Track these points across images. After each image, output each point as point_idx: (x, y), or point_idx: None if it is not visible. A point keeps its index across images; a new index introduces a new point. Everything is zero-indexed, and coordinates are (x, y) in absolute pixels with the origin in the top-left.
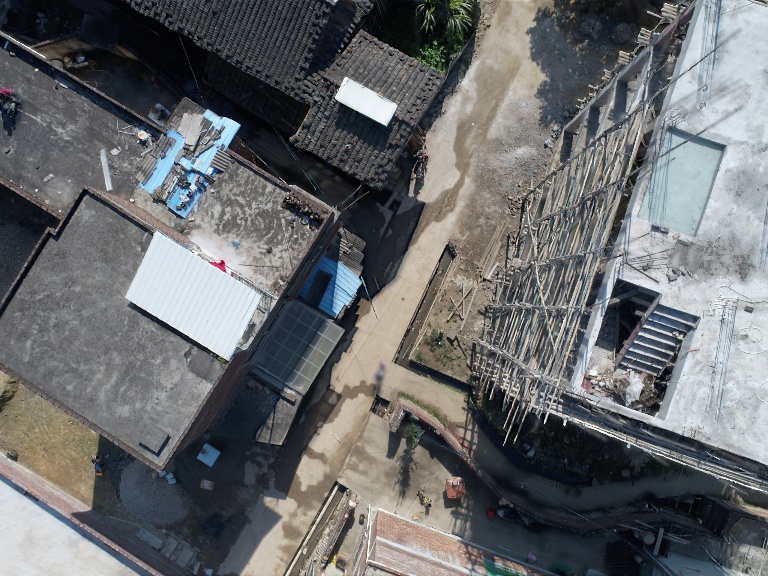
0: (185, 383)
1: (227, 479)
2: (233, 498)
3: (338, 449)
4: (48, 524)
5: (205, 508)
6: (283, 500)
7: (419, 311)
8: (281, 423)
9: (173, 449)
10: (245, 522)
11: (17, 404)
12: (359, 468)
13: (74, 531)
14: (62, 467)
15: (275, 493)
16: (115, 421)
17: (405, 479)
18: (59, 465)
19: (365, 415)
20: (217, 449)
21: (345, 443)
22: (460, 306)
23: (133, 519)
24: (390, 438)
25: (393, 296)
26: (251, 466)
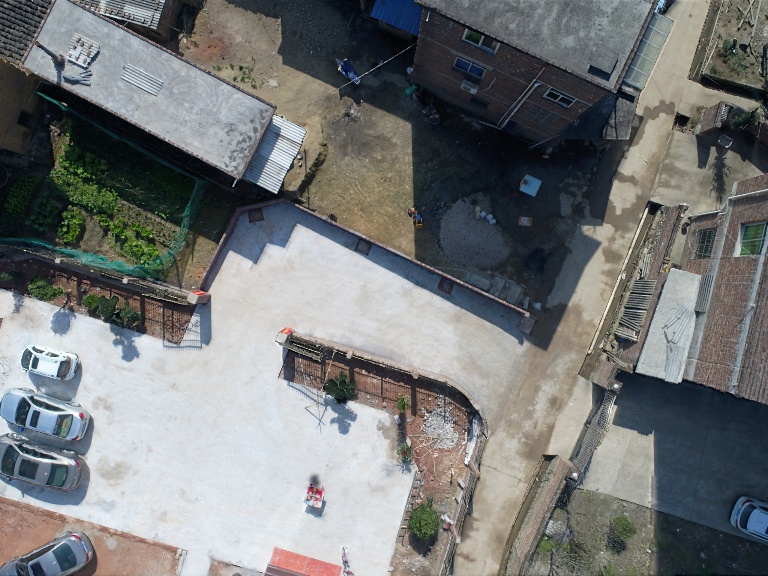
0: (625, 6)
1: (544, 213)
2: (552, 231)
3: (647, 170)
4: (381, 277)
5: (526, 245)
6: (600, 226)
7: (703, 29)
8: (623, 121)
9: (625, 68)
10: (566, 253)
11: (329, 168)
12: (671, 183)
13: (407, 280)
14: (381, 225)
15: (591, 221)
16: (561, 52)
17: (720, 185)
18: (378, 223)
19: (668, 133)
20: (538, 179)
21: (653, 163)
22: (748, 13)
23: (457, 265)
24: (699, 149)
25: (680, 14)
26: (566, 197)
